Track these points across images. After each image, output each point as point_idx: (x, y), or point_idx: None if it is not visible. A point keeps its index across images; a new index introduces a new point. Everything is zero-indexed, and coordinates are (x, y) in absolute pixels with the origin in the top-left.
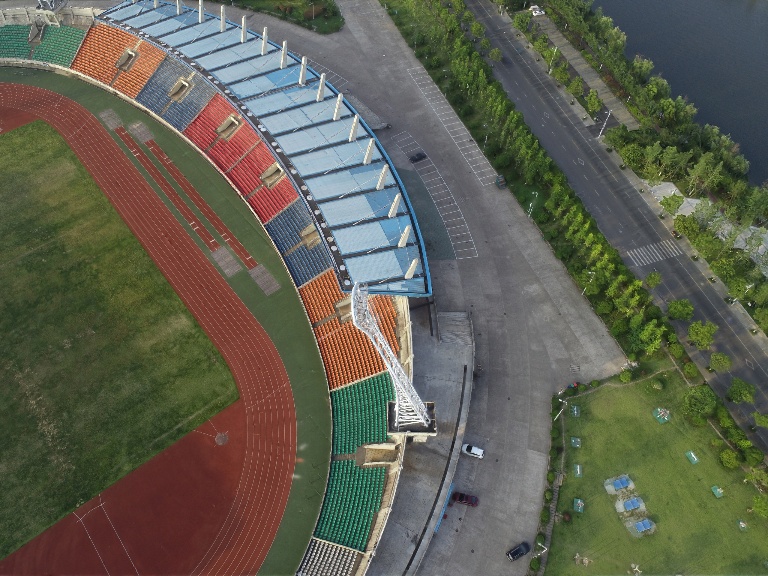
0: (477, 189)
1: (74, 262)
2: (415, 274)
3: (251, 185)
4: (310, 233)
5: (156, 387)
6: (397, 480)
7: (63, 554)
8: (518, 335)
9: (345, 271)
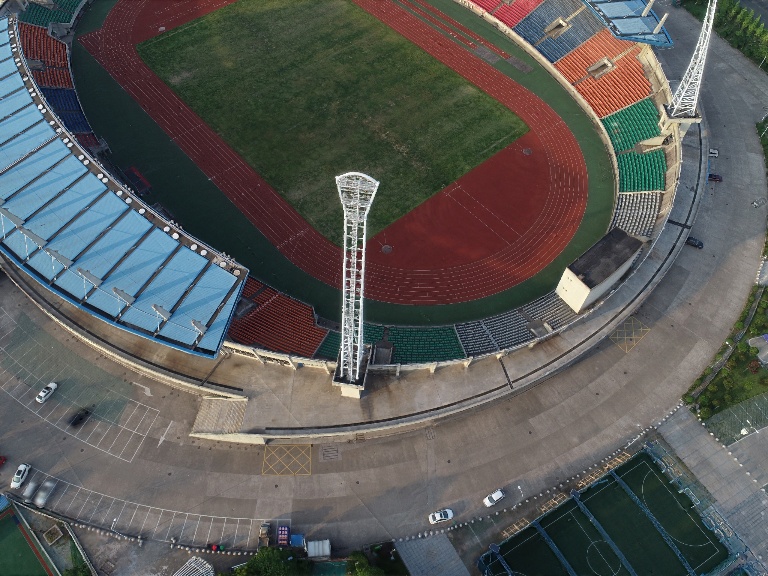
0: (659, 8)
1: (374, 57)
2: (658, 32)
3: (493, 5)
4: (551, 30)
5: (468, 125)
6: (681, 146)
7: (444, 212)
8: (719, 91)
9: (614, 26)
